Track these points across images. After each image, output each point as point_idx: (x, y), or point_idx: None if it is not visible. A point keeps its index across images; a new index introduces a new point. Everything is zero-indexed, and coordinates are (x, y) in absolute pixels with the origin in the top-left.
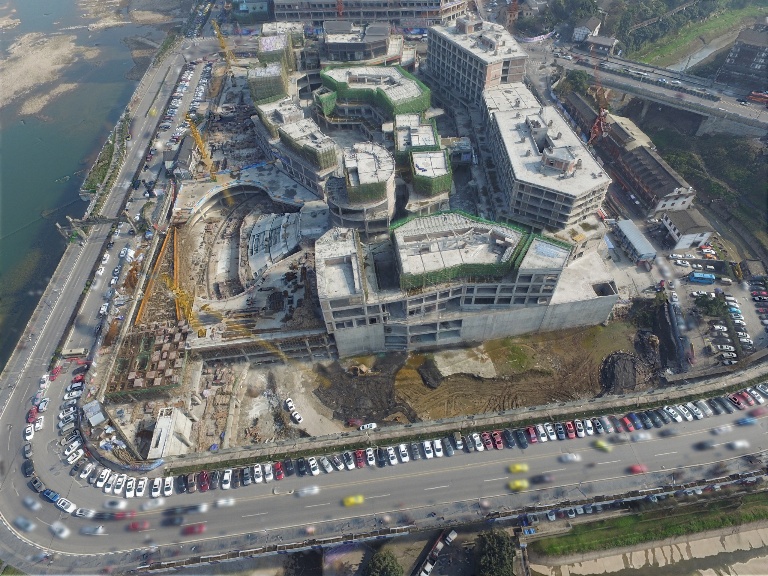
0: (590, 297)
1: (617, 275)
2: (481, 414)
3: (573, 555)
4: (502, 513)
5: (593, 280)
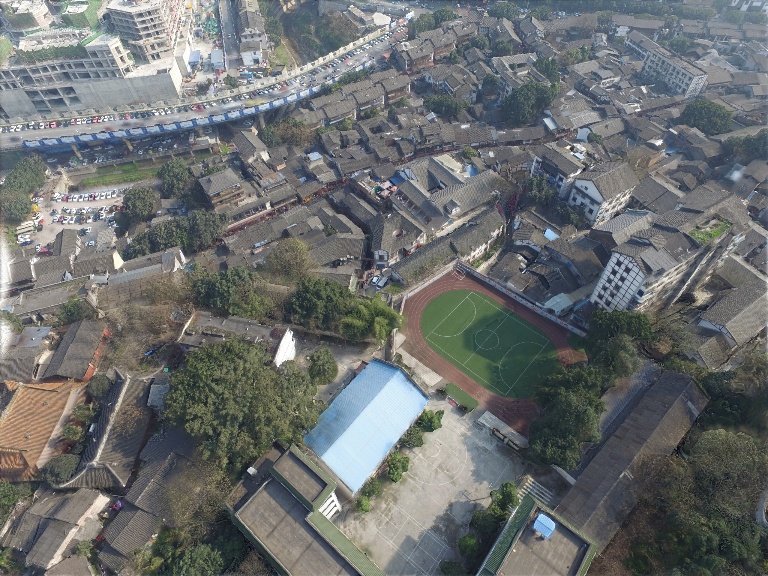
0: (151, 74)
1: (200, 77)
2: (49, 115)
3: (101, 187)
4: (30, 141)
5: (160, 68)
